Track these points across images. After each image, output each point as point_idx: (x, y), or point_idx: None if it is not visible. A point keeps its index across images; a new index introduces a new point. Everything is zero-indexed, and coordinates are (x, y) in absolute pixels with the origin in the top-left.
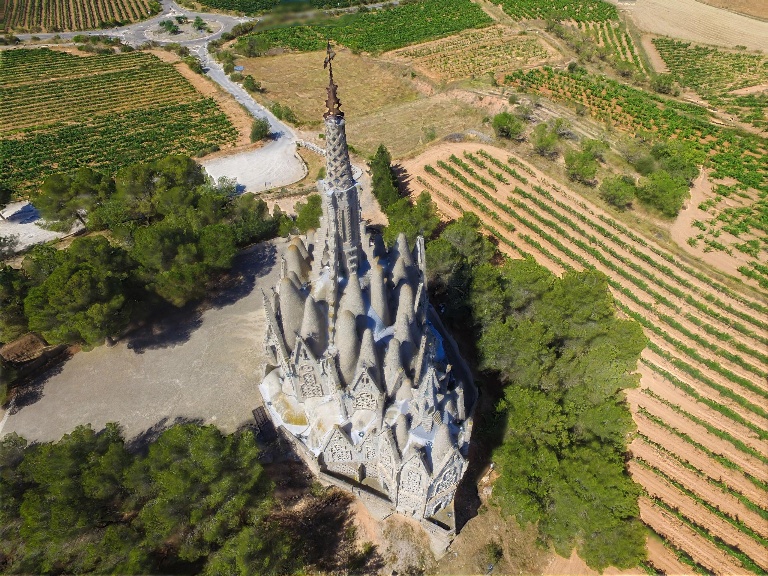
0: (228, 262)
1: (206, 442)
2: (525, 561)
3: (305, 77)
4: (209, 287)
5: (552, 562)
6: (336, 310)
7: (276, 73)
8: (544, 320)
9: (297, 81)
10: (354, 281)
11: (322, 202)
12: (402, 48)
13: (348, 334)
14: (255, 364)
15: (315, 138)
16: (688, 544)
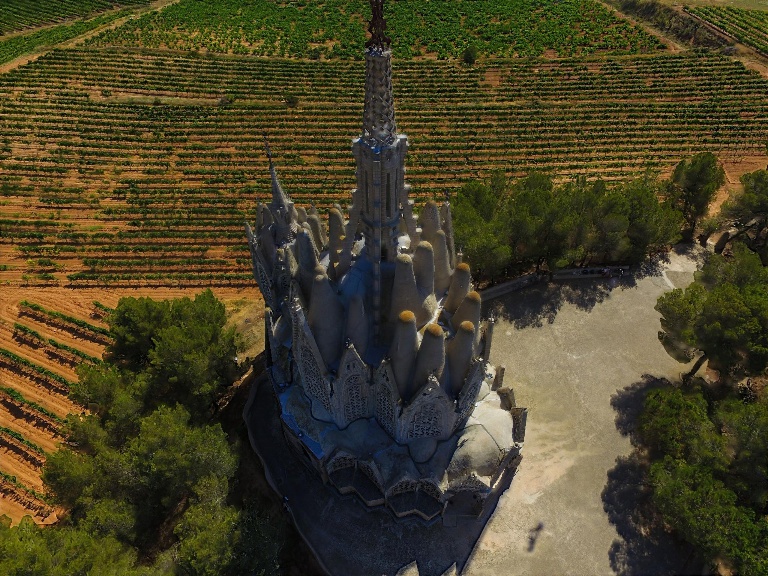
0: None
1: None
2: None
3: None
4: None
5: None
6: None
7: None
8: (123, 526)
9: None
10: None
11: None
12: None
13: None
14: None
15: None
16: (64, 408)
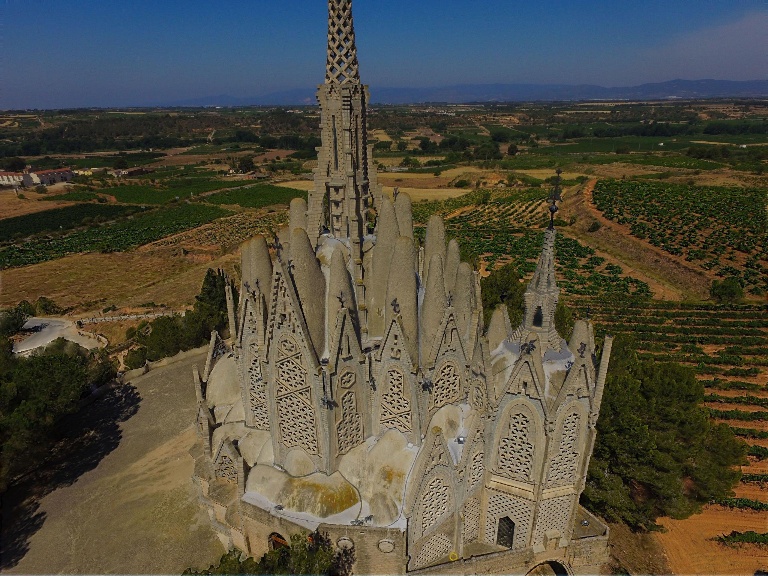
0: (77, 396)
1: (240, 574)
2: (650, 570)
3: (48, 282)
4: (35, 465)
5: (666, 554)
6: (362, 277)
7: (2, 287)
8: None
9: (38, 287)
10: (391, 205)
11: (323, 117)
12: (158, 240)
13: (410, 274)
14: (185, 518)
15: (98, 314)
16: None
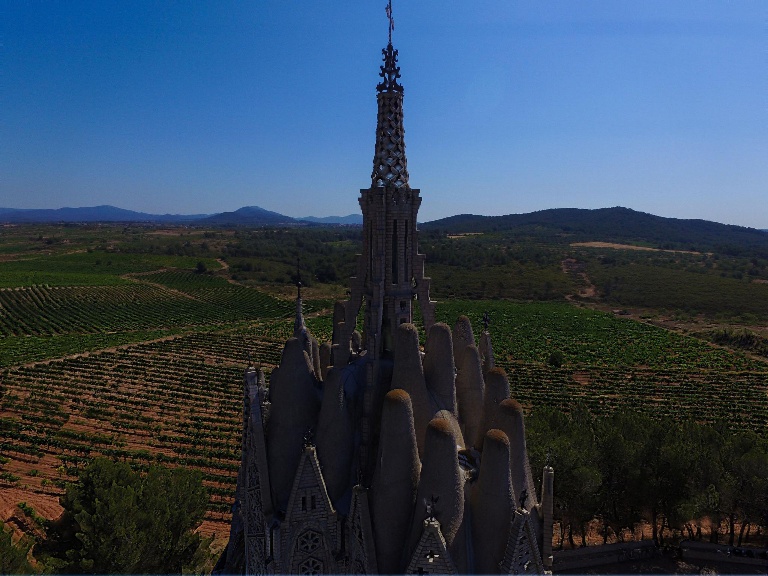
0: None
1: None
2: None
3: None
4: None
5: None
6: None
7: None
8: None
9: None
10: None
11: None
12: None
13: None
14: None
15: None
16: None
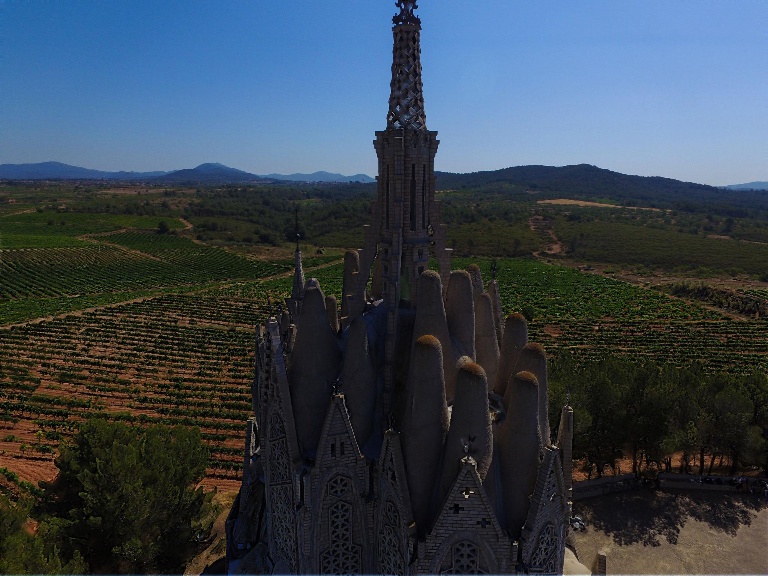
0: None
1: None
2: None
3: None
4: None
5: None
6: None
7: None
8: None
9: None
10: None
11: None
12: None
13: None
14: None
15: None
16: None
